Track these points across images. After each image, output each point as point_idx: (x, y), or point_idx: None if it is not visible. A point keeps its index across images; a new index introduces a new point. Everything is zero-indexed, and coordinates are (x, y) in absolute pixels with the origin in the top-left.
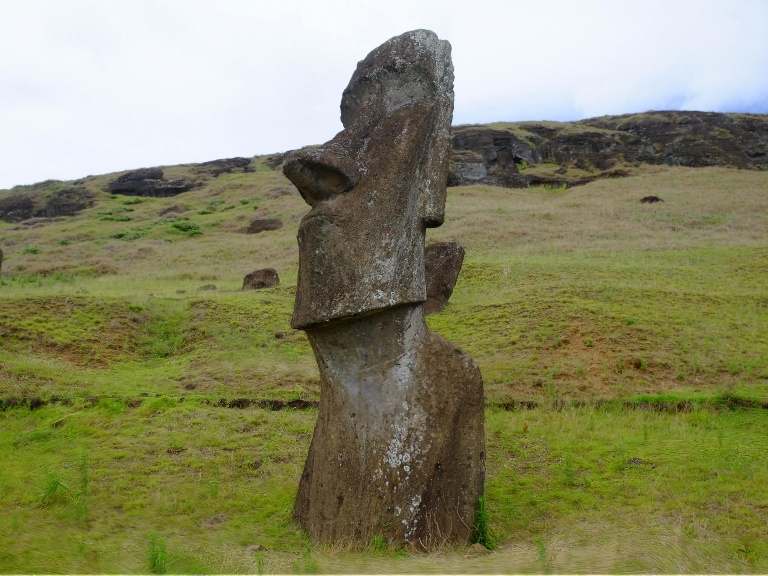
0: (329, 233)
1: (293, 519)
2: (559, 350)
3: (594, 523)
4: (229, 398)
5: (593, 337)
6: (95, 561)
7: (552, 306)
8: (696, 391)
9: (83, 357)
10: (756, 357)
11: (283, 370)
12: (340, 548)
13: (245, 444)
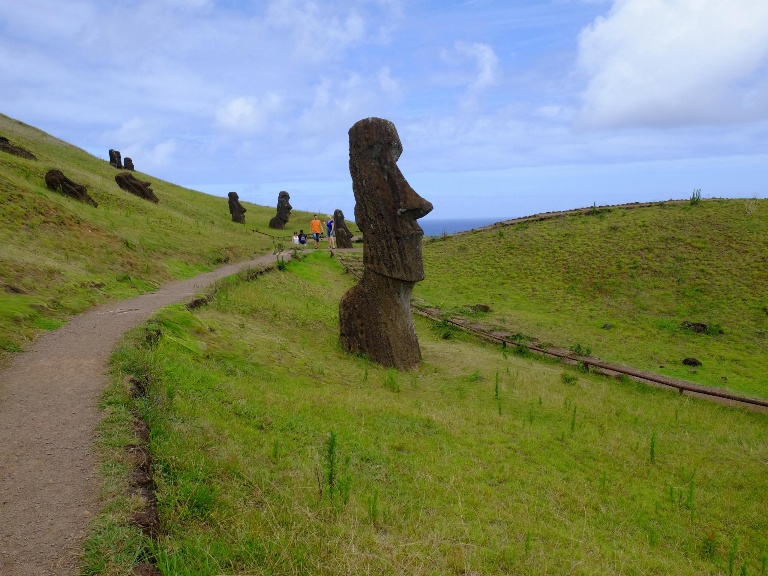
0: None
1: (384, 366)
2: (70, 227)
3: None
4: None
5: (64, 213)
6: (478, 384)
7: None
8: None
9: None
10: (140, 237)
11: (10, 257)
12: (414, 369)
13: None
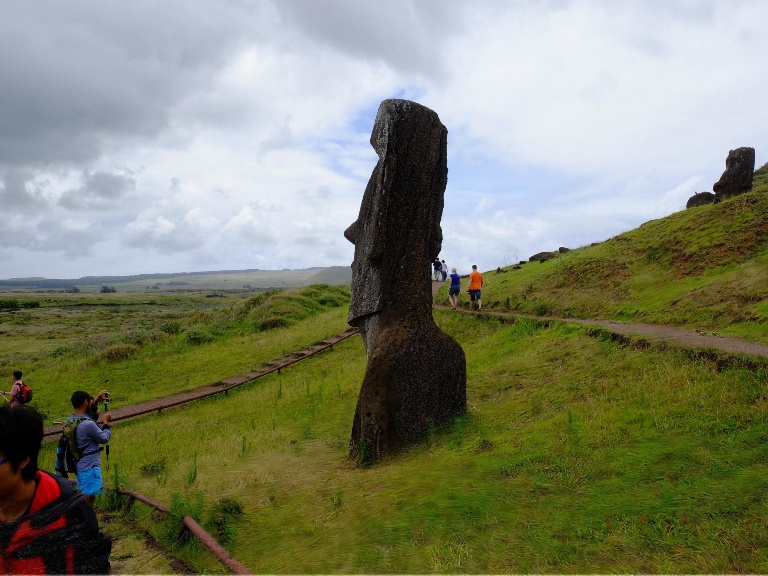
0: None
1: None
2: None
3: None
4: (594, 328)
5: None
6: None
7: None
8: None
9: (692, 265)
10: None
11: (751, 280)
12: None
13: (529, 372)
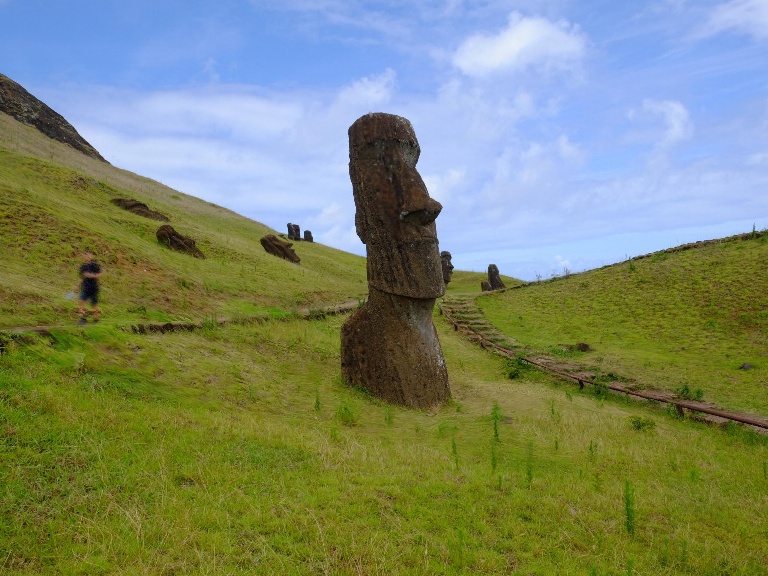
0: None
1: (389, 403)
2: (121, 265)
3: None
4: None
5: (124, 254)
6: None
7: (45, 213)
8: (229, 305)
9: None
10: (213, 280)
11: None
12: (435, 408)
13: None
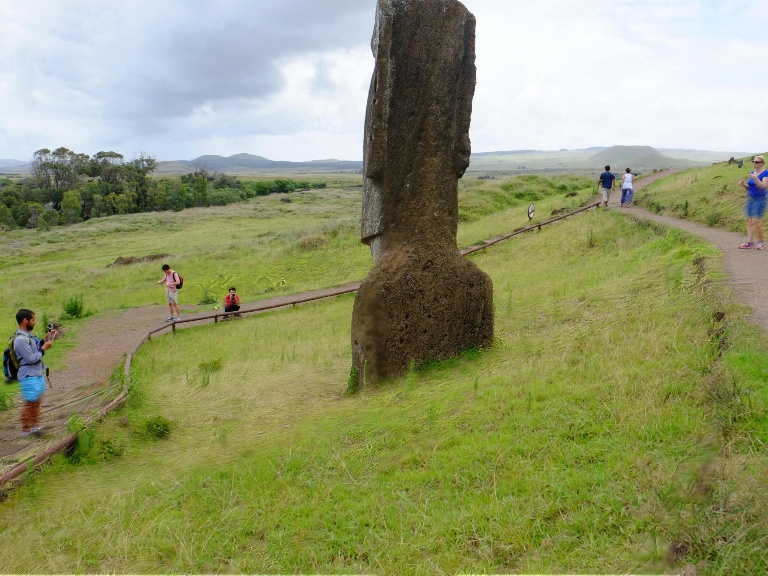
0: None
1: None
2: None
3: (330, 405)
4: None
5: None
6: None
7: None
8: None
9: None
10: None
11: None
12: None
13: None
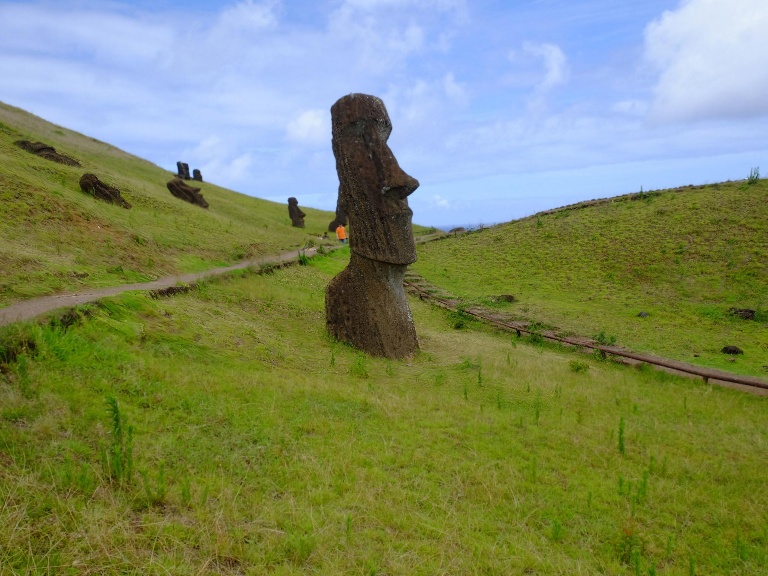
0: (409, 220)
1: (372, 355)
2: (77, 223)
3: None
4: (150, 291)
5: None
6: None
7: None
8: None
9: None
10: (158, 234)
11: None
12: (408, 358)
13: None
